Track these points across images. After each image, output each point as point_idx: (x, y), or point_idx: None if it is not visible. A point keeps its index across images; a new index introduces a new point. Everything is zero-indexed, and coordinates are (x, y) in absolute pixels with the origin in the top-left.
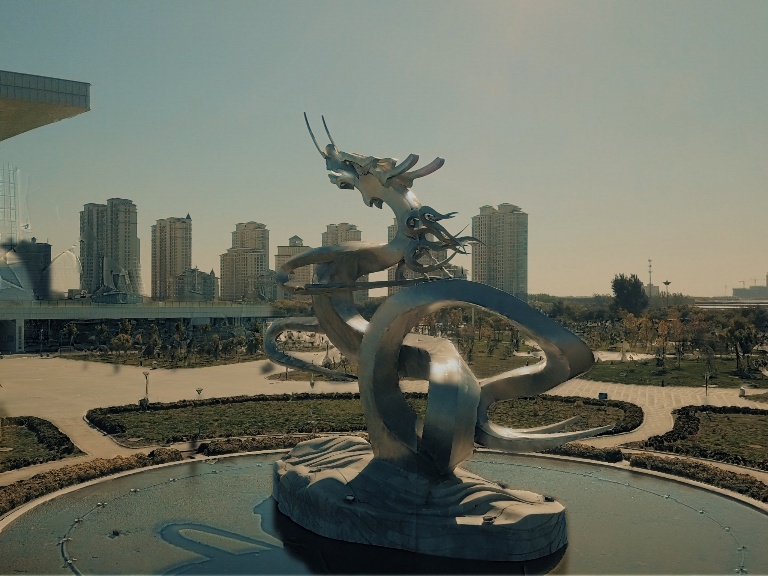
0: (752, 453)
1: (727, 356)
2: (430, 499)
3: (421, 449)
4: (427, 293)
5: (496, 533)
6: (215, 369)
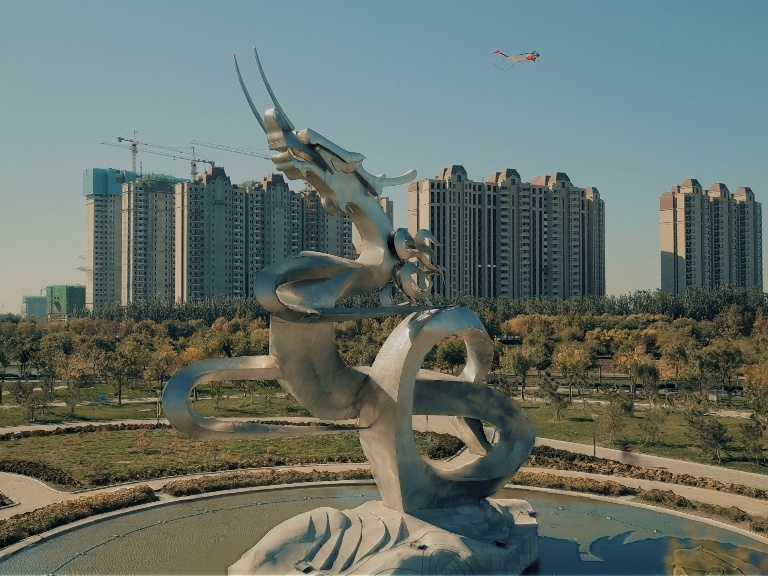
0: (161, 465)
1: None
2: None
3: None
4: None
5: None
6: None
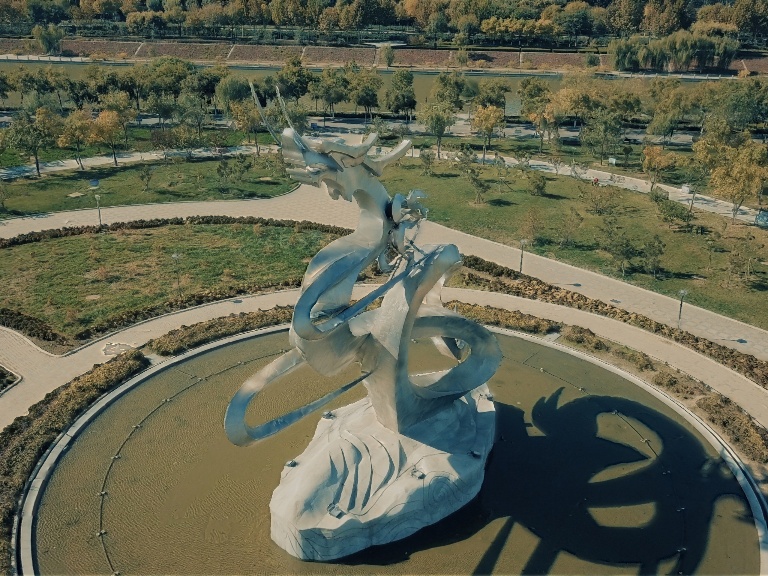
0: (130, 302)
1: None
2: None
3: None
4: None
5: None
6: None
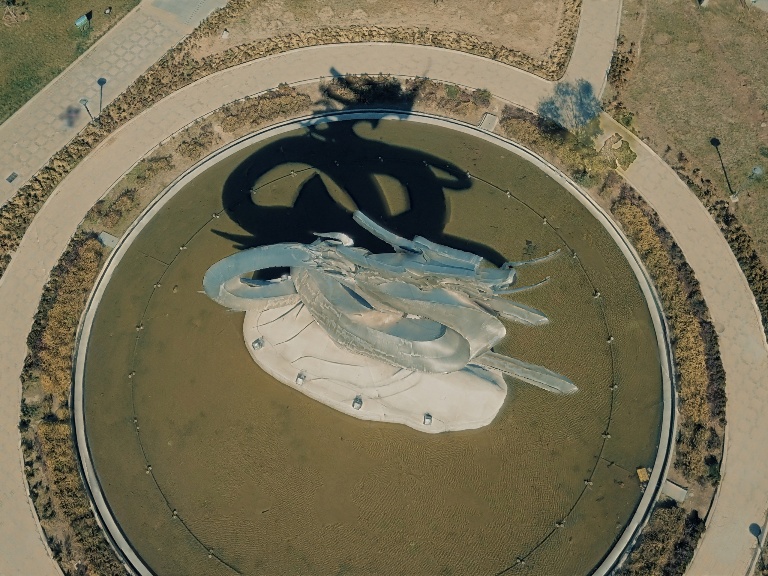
0: None
1: None
2: None
3: None
4: None
5: None
6: None
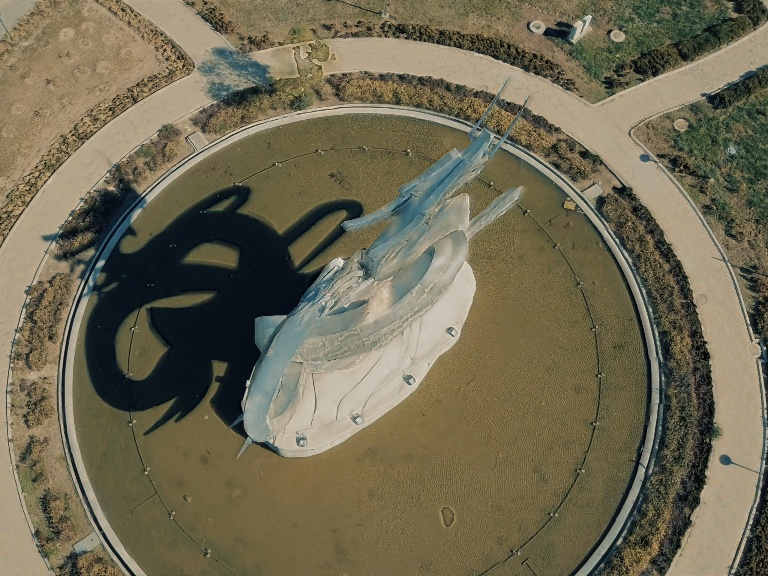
0: None
1: None
2: None
3: None
4: None
5: None
6: None
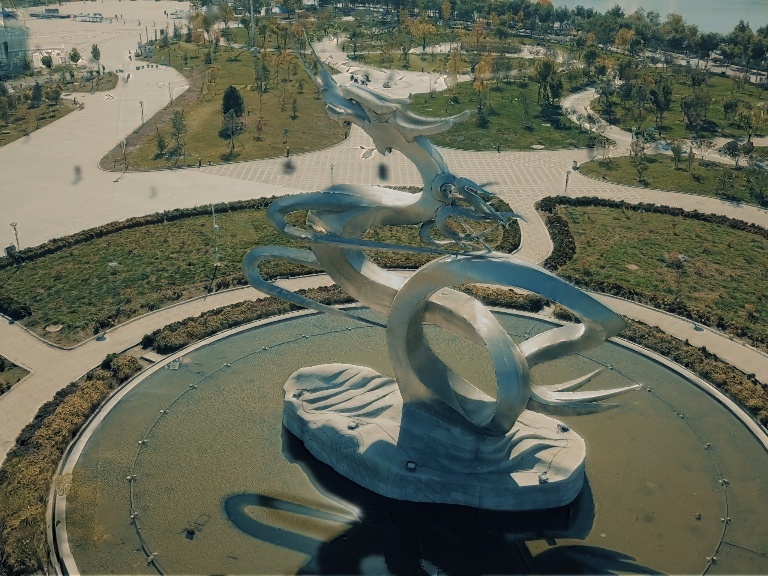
0: (637, 281)
1: (520, 81)
2: (479, 454)
3: (484, 427)
4: (474, 273)
5: (551, 488)
6: (24, 149)
